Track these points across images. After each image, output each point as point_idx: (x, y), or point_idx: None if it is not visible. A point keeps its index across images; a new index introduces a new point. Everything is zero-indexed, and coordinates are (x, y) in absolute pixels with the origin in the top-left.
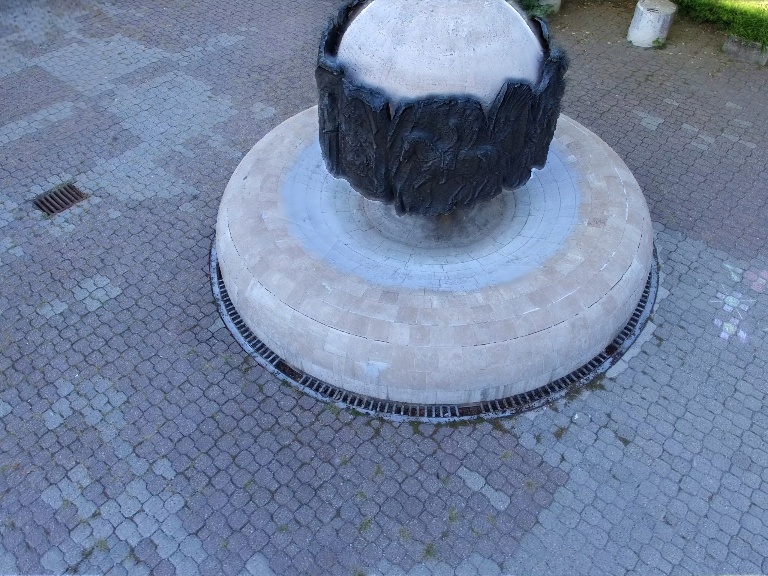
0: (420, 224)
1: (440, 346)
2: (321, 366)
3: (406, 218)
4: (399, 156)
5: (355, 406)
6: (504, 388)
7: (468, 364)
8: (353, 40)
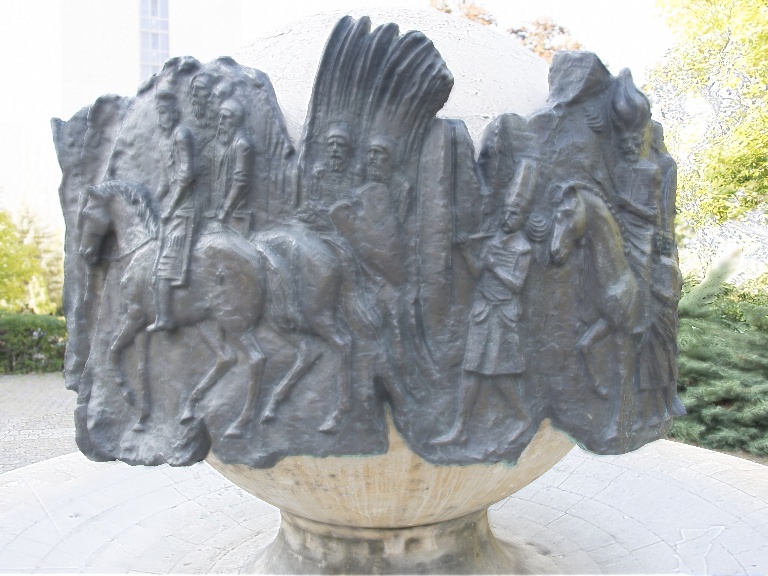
0: None
1: None
2: None
3: (266, 575)
4: None
5: None
6: None
7: None
8: None
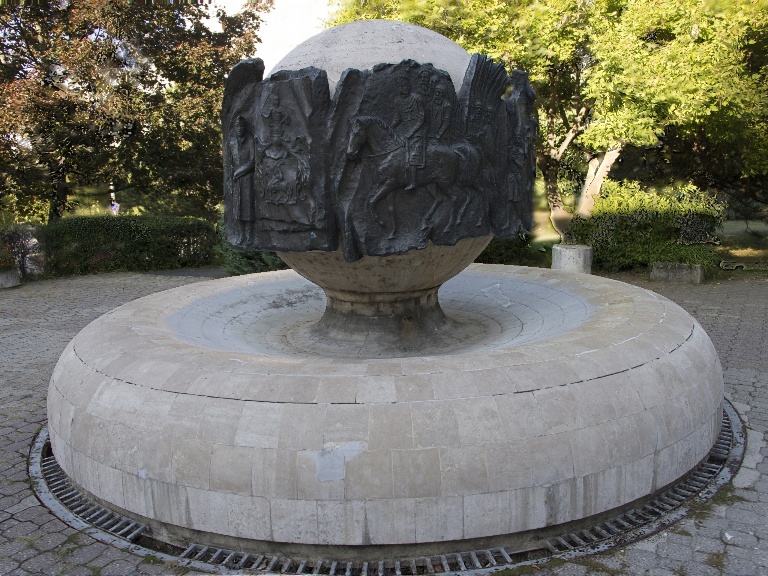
0: (374, 337)
1: (454, 397)
2: (227, 489)
3: (352, 334)
4: (345, 149)
5: (299, 574)
6: (583, 485)
7: (511, 425)
8: (271, 71)
